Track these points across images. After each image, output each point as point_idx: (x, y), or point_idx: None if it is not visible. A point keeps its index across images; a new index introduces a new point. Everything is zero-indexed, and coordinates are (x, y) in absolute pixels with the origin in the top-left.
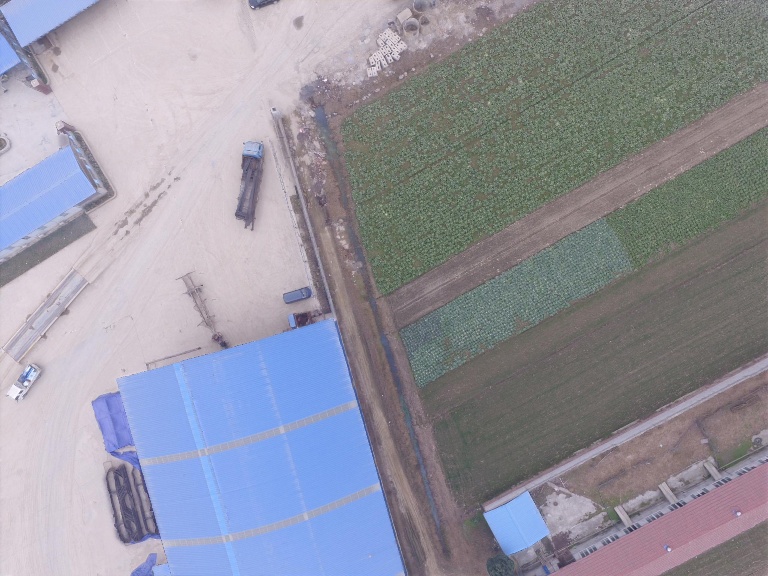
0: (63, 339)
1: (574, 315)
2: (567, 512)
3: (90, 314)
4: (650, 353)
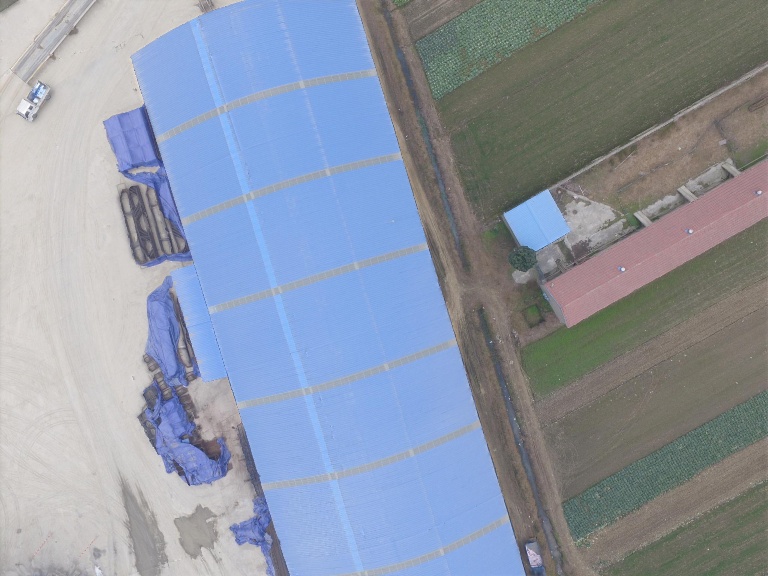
0: (72, 59)
1: (591, 20)
2: (586, 220)
3: (99, 33)
4: (667, 55)
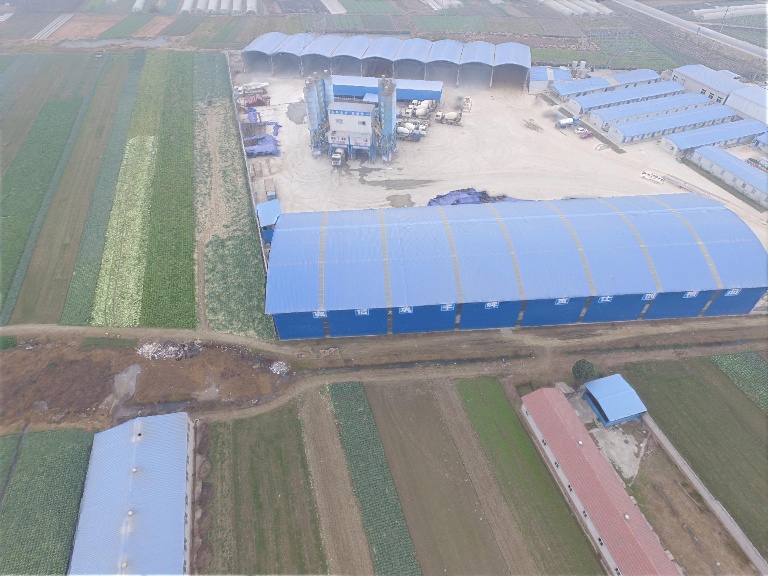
0: None
1: None
2: (620, 451)
3: None
4: None
